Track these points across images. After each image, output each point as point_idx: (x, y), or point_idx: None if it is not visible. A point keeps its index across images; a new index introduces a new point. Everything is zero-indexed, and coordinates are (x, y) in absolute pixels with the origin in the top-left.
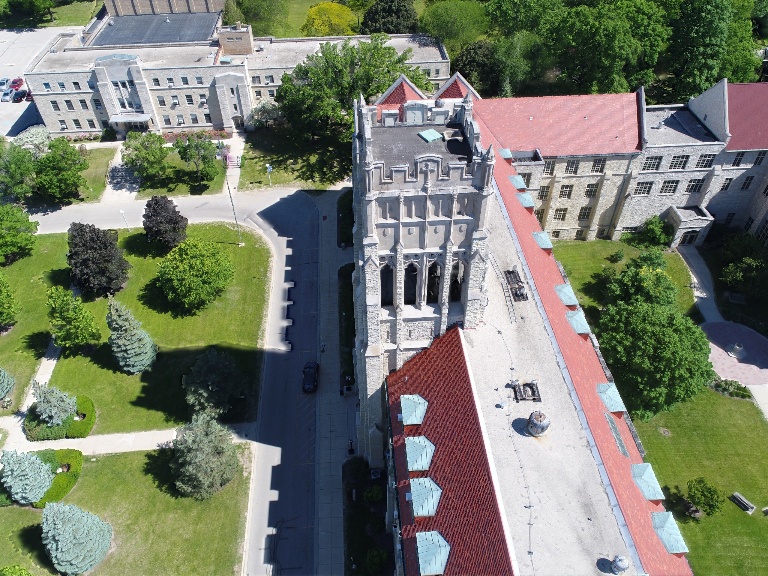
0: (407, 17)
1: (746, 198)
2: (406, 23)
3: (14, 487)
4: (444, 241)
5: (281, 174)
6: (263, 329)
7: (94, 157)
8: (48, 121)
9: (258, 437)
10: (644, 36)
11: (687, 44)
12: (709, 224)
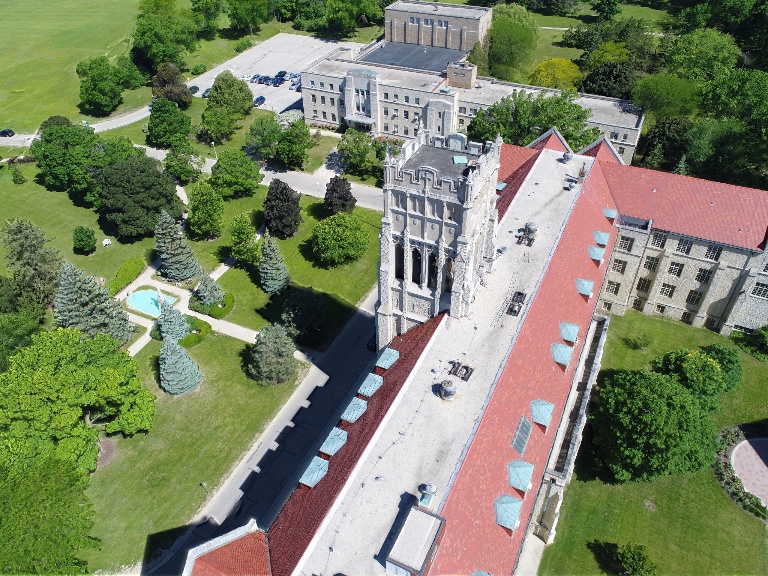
0: (624, 83)
1: None
2: (621, 88)
3: (163, 327)
4: (439, 237)
5: None
6: (367, 295)
7: (325, 142)
8: (306, 109)
9: (319, 364)
10: None
11: None
12: None
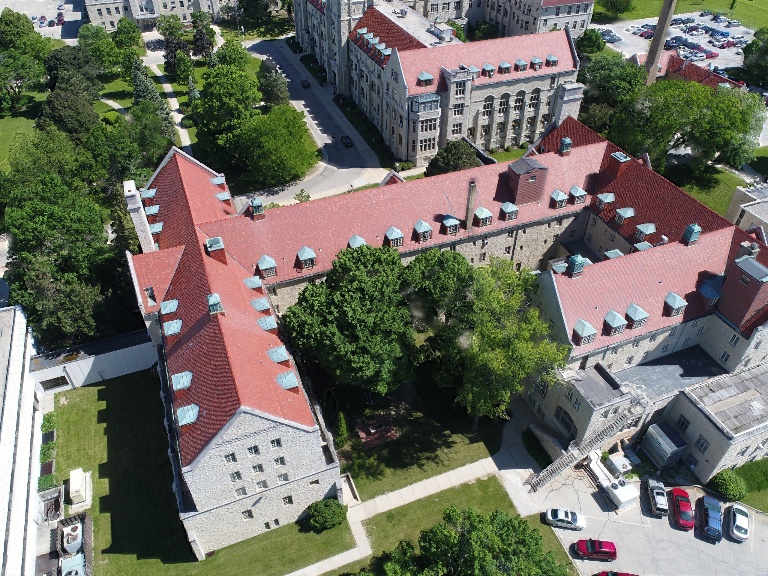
0: None
1: (481, 12)
2: None
3: None
4: None
5: (247, 36)
6: None
7: None
8: None
9: None
10: None
11: None
12: (467, 22)
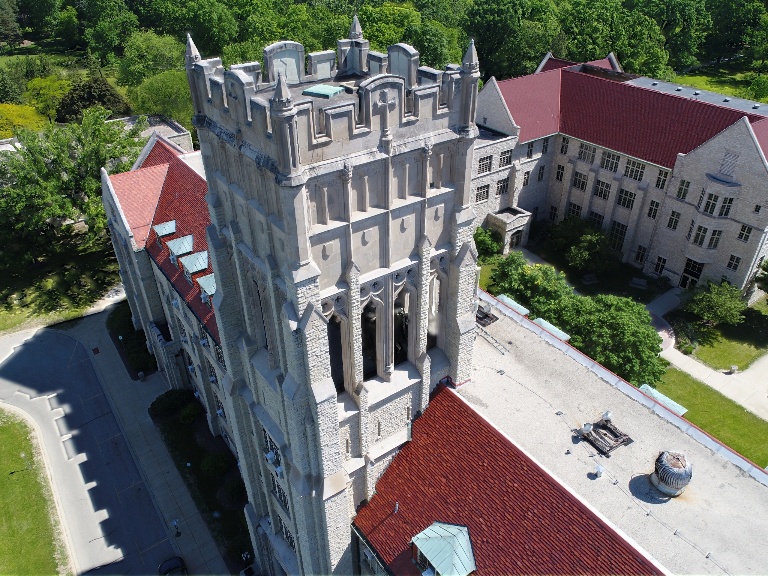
0: (115, 102)
1: (543, 189)
2: (116, 108)
3: None
4: (414, 244)
5: (3, 317)
6: (60, 546)
7: None
8: None
9: None
10: None
11: None
12: (529, 220)
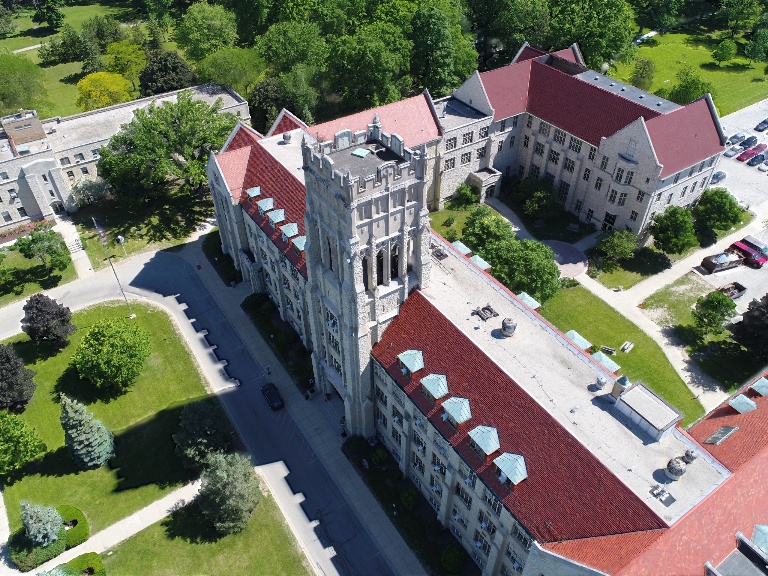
0: (185, 72)
1: (514, 153)
2: (186, 77)
3: None
4: (400, 225)
5: (131, 243)
6: (203, 377)
7: None
8: None
9: (257, 462)
10: (395, 50)
11: (426, 50)
12: (500, 178)
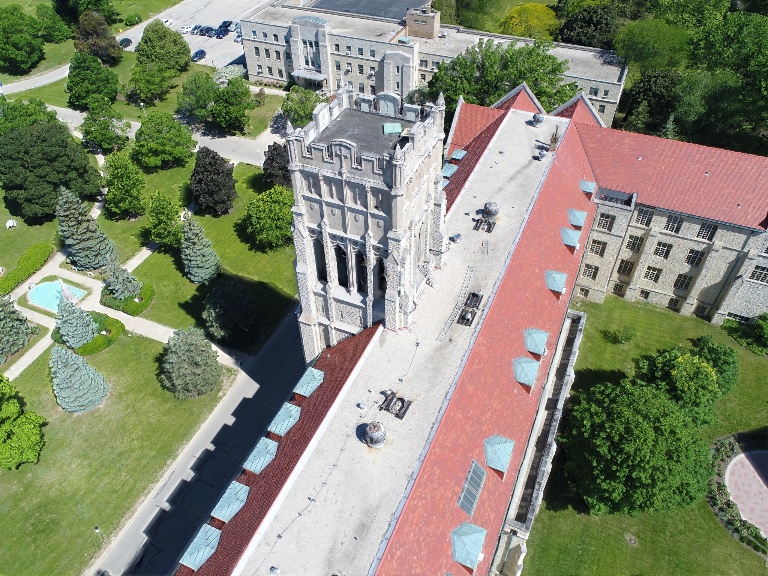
0: (605, 31)
1: None
2: (602, 37)
3: (62, 329)
4: (365, 232)
5: None
6: None
7: (271, 102)
8: (250, 63)
9: (249, 369)
10: None
11: None
12: None
